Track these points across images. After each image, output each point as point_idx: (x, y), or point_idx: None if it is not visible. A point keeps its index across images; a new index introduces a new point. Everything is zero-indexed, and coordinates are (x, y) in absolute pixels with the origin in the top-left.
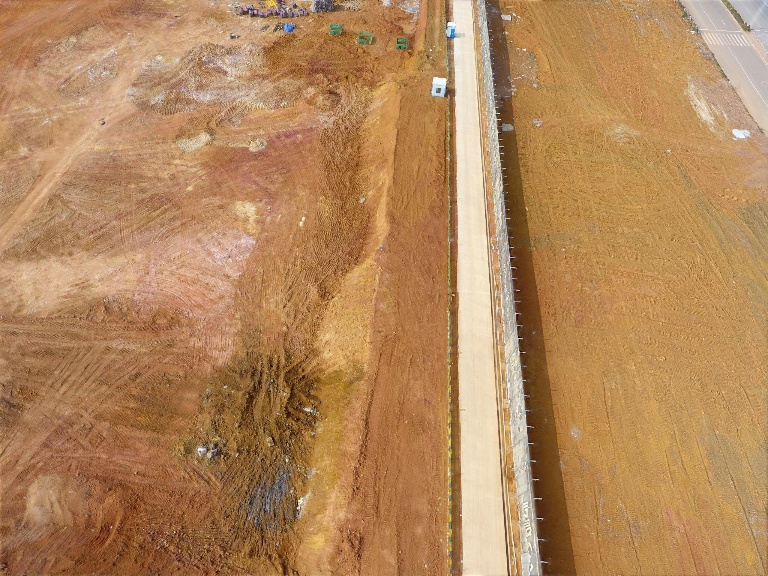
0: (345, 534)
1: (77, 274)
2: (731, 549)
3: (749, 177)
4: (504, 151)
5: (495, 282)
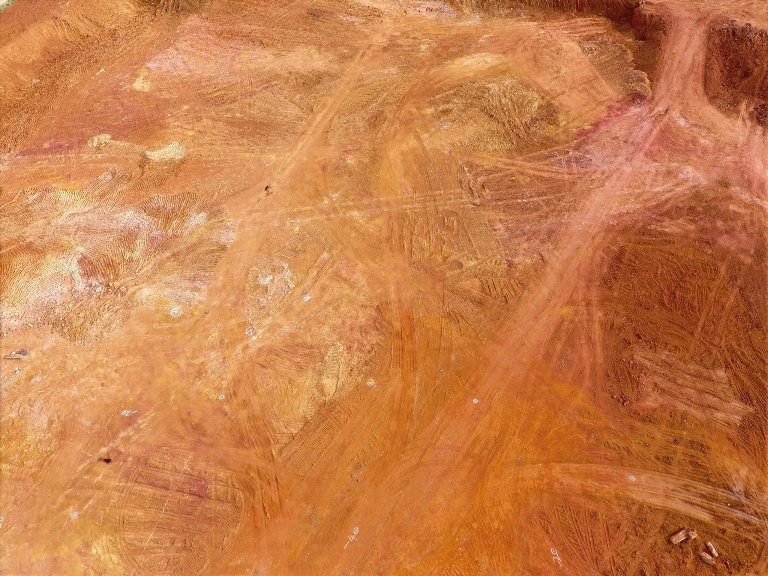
0: None
1: (283, 61)
2: None
3: None
4: None
5: None
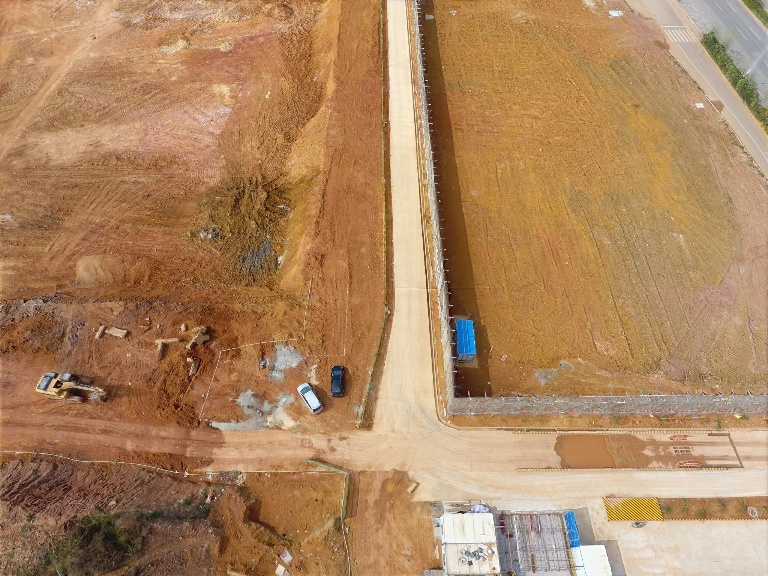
0: (311, 255)
1: (90, 138)
2: (579, 246)
3: (618, 41)
4: (426, 32)
5: (418, 114)
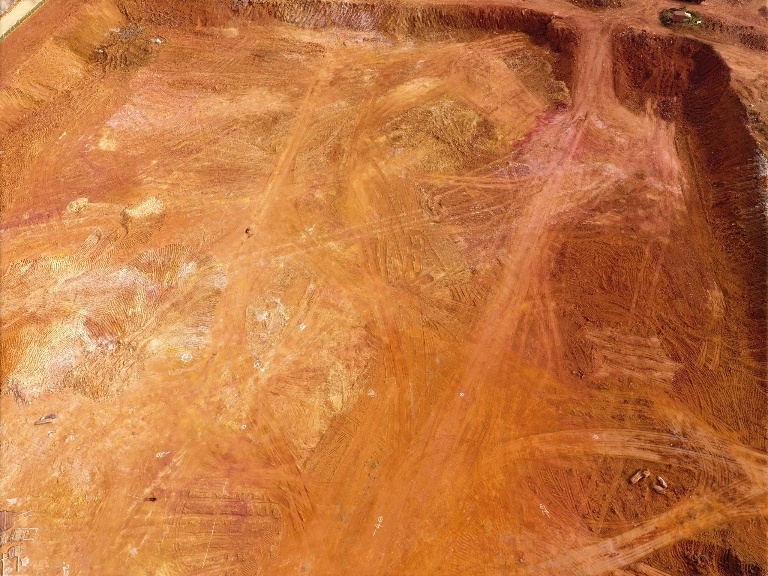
0: (89, 2)
1: (239, 105)
2: None
3: None
4: None
5: None
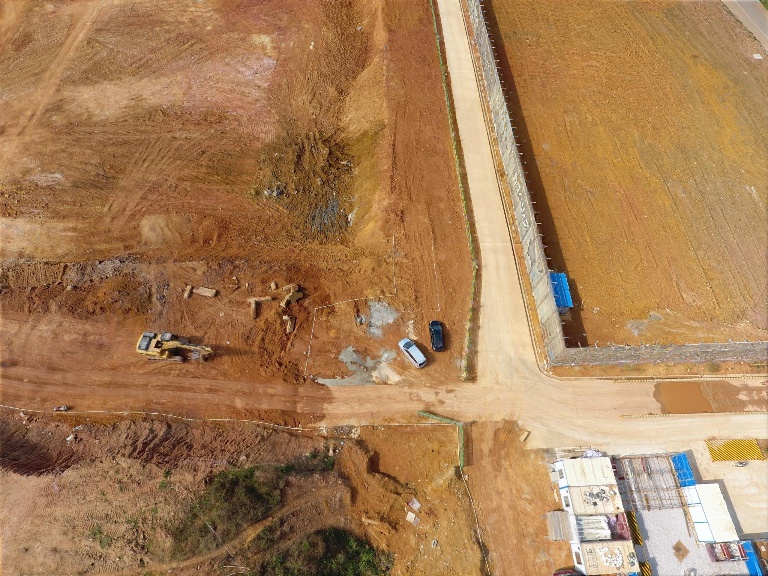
0: (390, 211)
1: (130, 92)
2: (655, 199)
3: None
4: None
5: (477, 65)
